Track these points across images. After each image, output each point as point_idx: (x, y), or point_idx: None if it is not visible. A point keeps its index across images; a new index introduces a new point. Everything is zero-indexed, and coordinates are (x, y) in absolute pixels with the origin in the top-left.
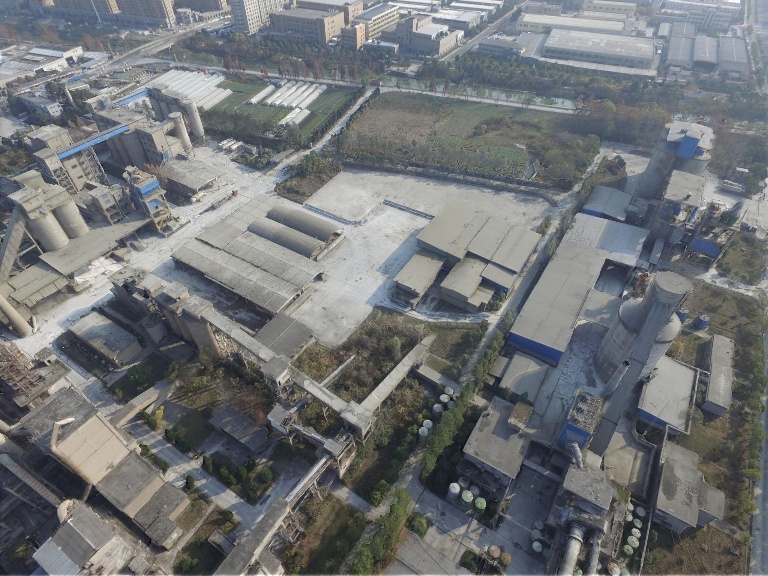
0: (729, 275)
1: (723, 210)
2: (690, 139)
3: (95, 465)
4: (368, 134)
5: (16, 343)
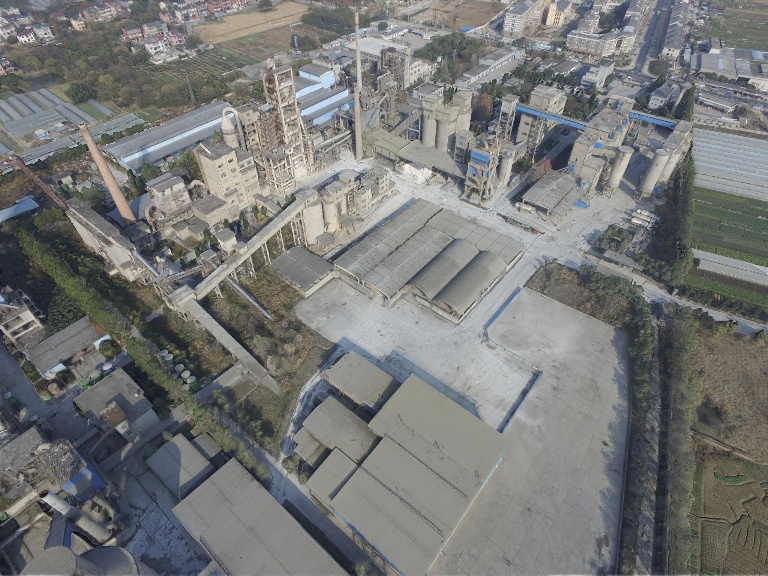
0: None
1: None
2: None
3: None
4: (751, 366)
5: (351, 158)
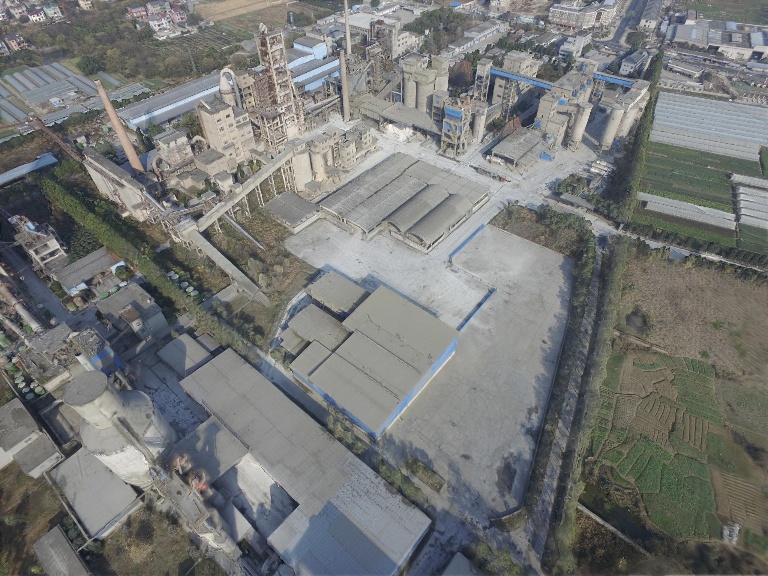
0: None
1: None
2: None
3: (211, 138)
4: (679, 284)
5: (340, 120)
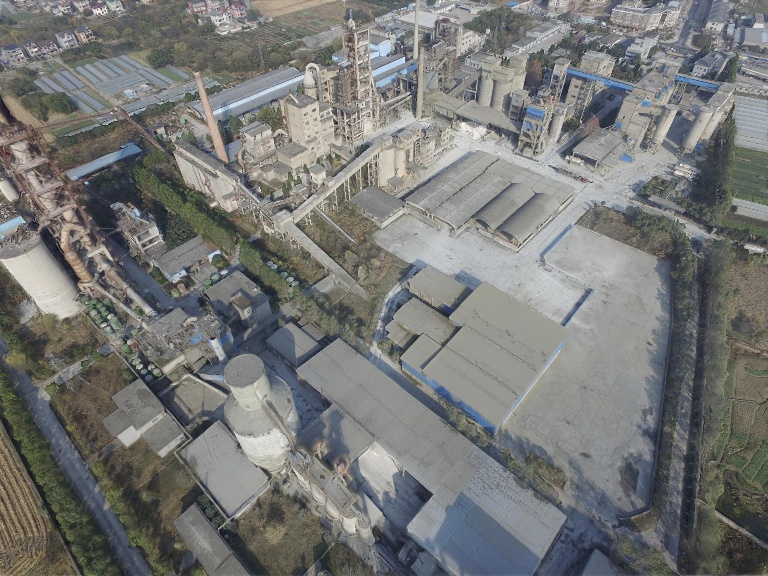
0: None
1: None
2: None
3: None
4: None
5: (411, 117)
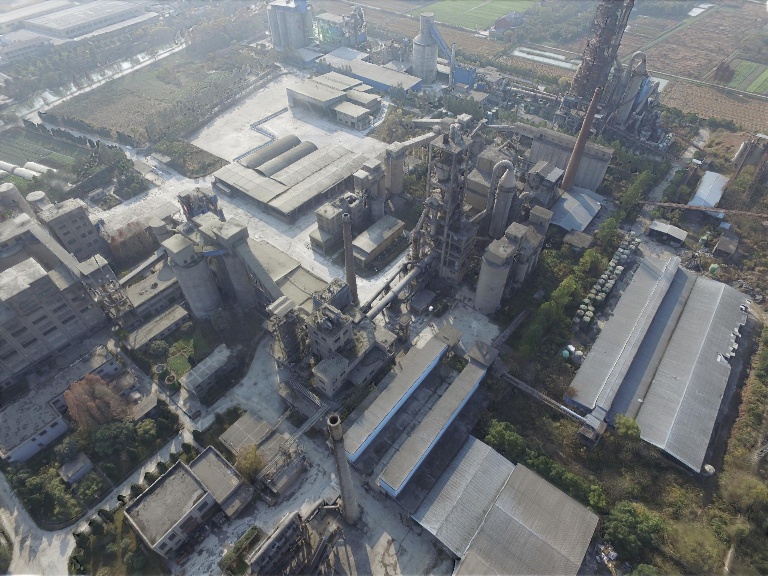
0: (372, 47)
1: (357, 14)
2: None
3: None
4: None
5: None
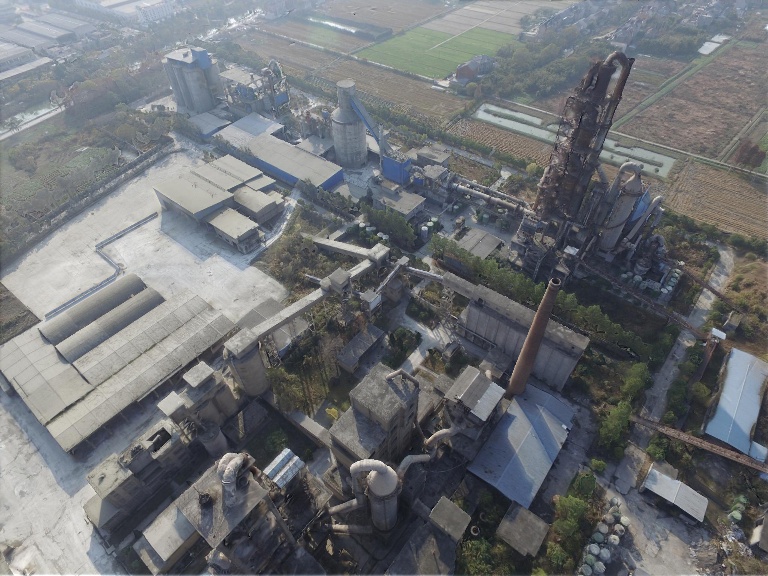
0: (298, 106)
1: (271, 71)
2: (202, 53)
3: None
4: None
5: None
